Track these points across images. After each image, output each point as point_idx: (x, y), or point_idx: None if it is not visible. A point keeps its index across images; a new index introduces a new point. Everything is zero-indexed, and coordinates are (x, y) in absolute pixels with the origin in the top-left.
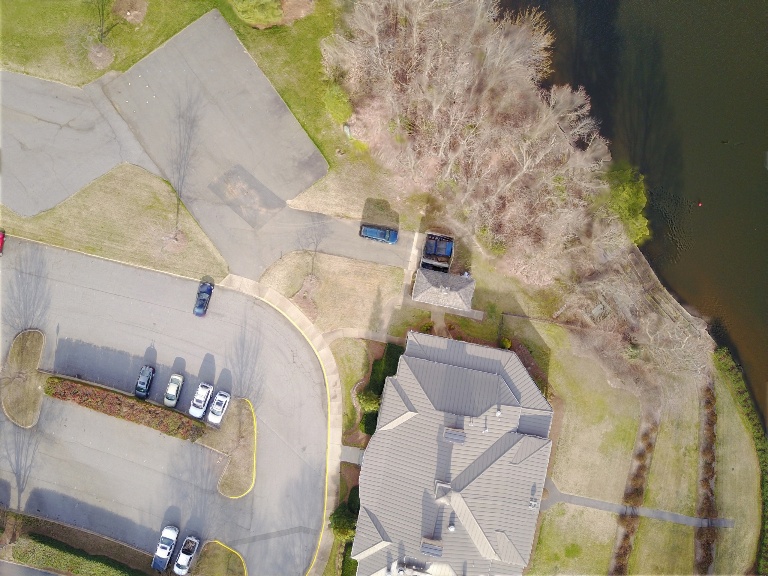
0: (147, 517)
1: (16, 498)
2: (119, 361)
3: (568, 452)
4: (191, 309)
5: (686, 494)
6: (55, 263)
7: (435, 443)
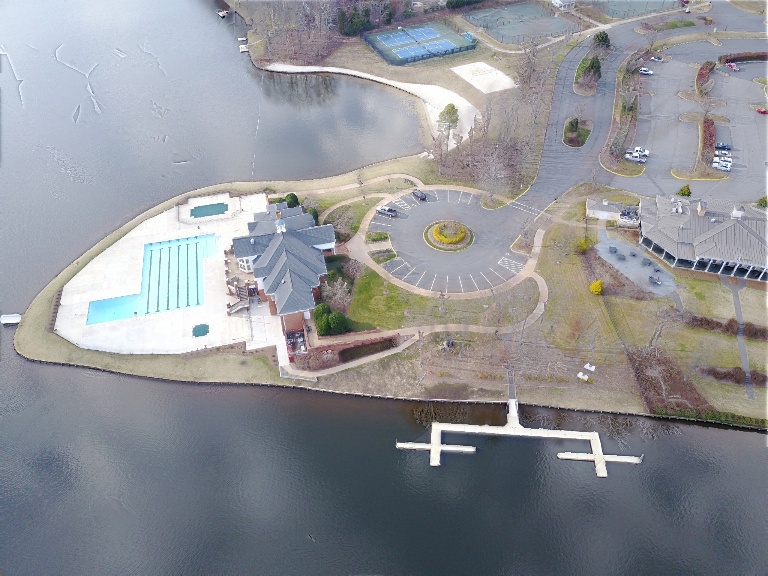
0: (649, 149)
1: (644, 116)
2: (727, 141)
3: (767, 297)
4: (767, 162)
5: (765, 364)
6: (765, 126)
7: (759, 217)
